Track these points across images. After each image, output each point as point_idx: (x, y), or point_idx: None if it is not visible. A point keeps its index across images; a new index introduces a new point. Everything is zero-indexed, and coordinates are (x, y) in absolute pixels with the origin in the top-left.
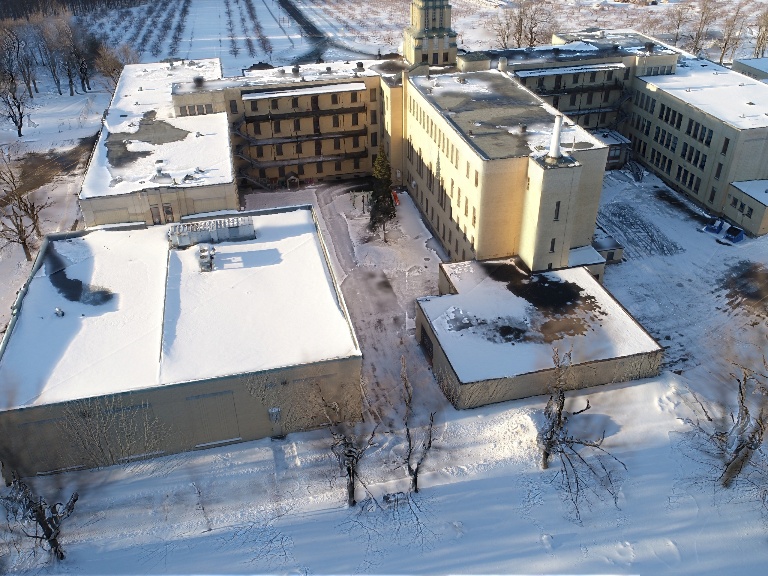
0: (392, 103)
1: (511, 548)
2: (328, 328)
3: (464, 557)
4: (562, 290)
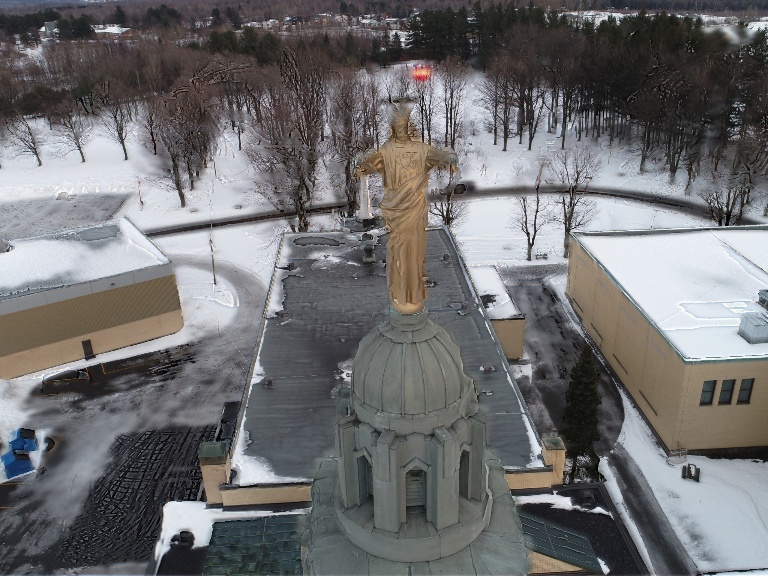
0: None
1: (480, 242)
2: (602, 250)
3: (505, 241)
4: None
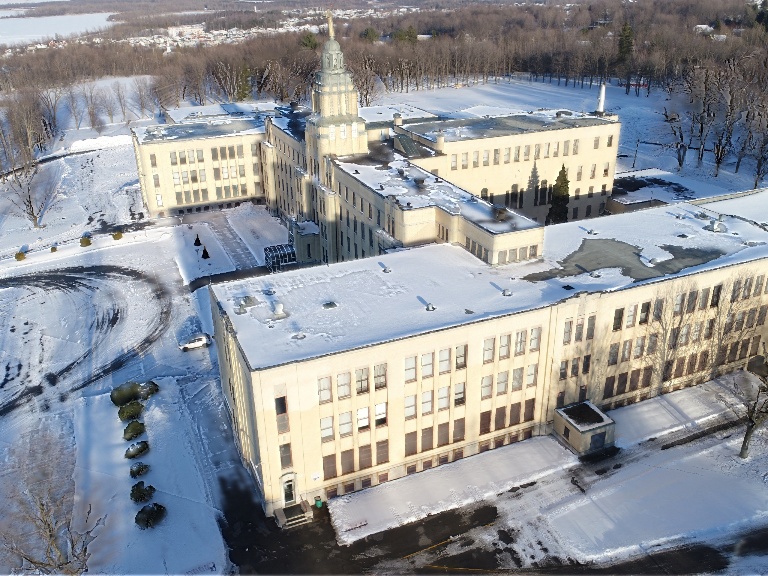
0: (446, 171)
1: None
2: None
3: None
4: (621, 182)
